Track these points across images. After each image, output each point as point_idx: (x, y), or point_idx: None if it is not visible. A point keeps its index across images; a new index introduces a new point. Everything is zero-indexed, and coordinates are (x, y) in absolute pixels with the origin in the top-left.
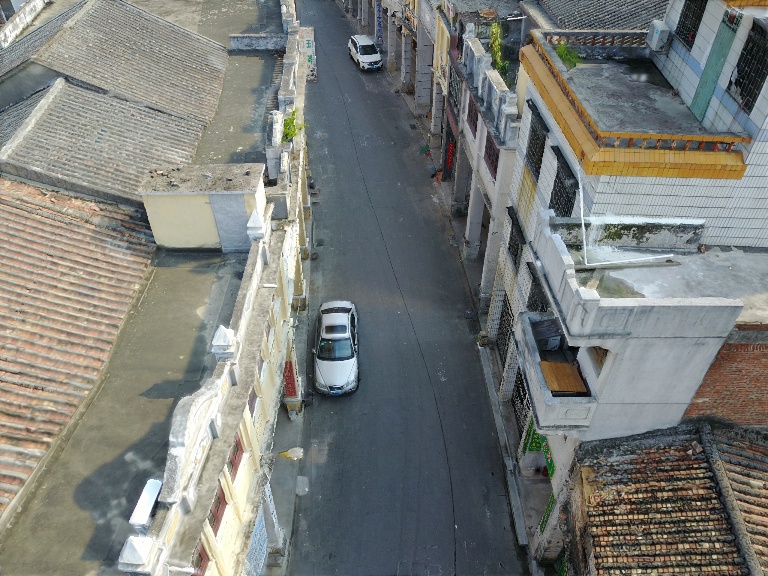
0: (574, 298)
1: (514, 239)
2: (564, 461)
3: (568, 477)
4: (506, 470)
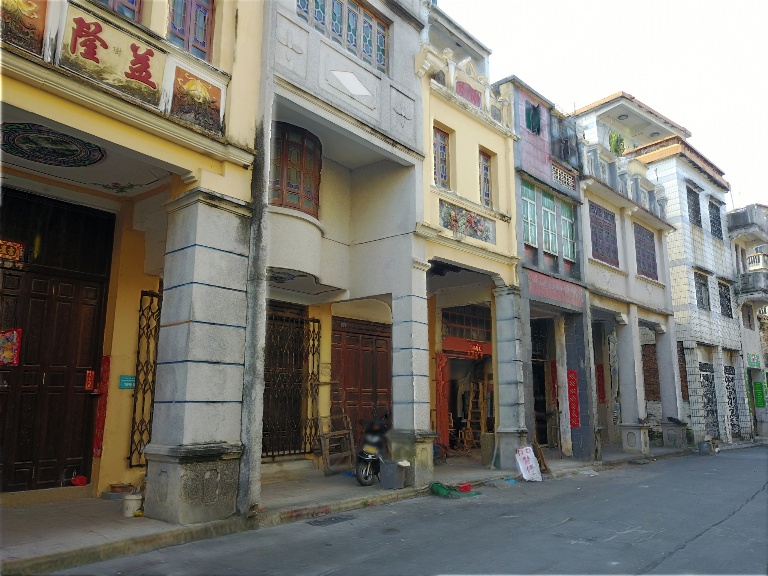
0: (767, 221)
1: (698, 291)
2: (758, 340)
3: (760, 342)
4: (762, 443)
